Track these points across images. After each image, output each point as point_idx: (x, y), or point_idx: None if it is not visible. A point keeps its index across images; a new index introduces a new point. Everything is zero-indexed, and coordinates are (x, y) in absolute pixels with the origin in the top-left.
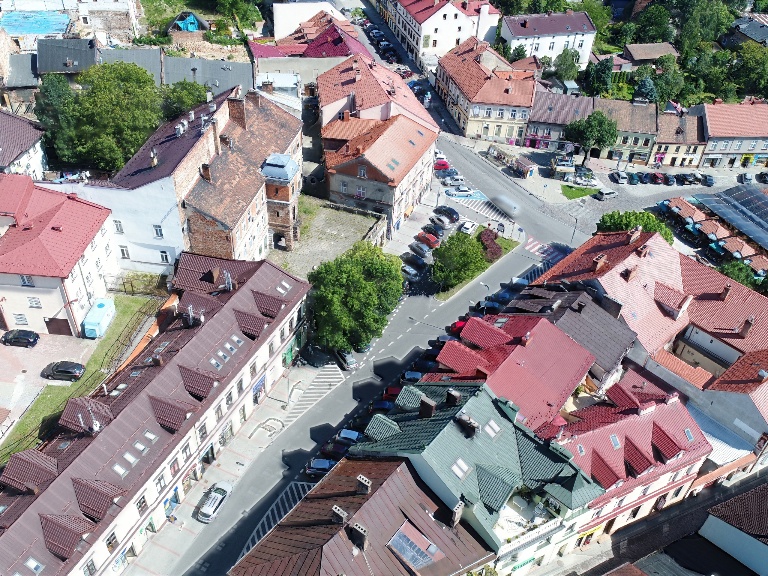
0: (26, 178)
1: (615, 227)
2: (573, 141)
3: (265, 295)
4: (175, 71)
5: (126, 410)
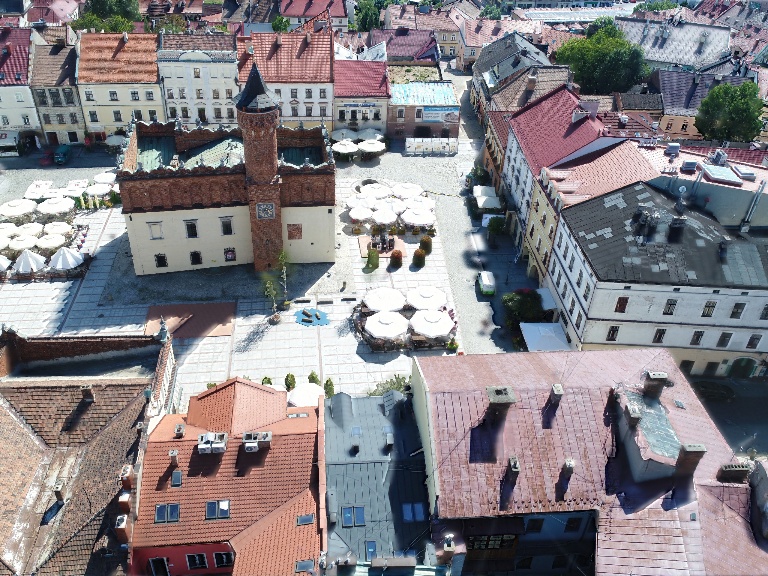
0: None
1: None
2: None
3: None
4: None
5: None
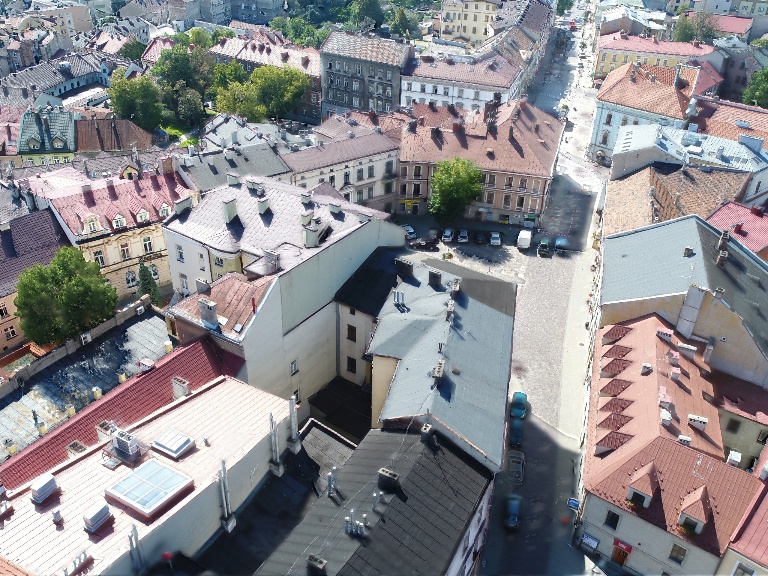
0: None
1: None
2: None
3: (6, 167)
4: None
5: (119, 156)
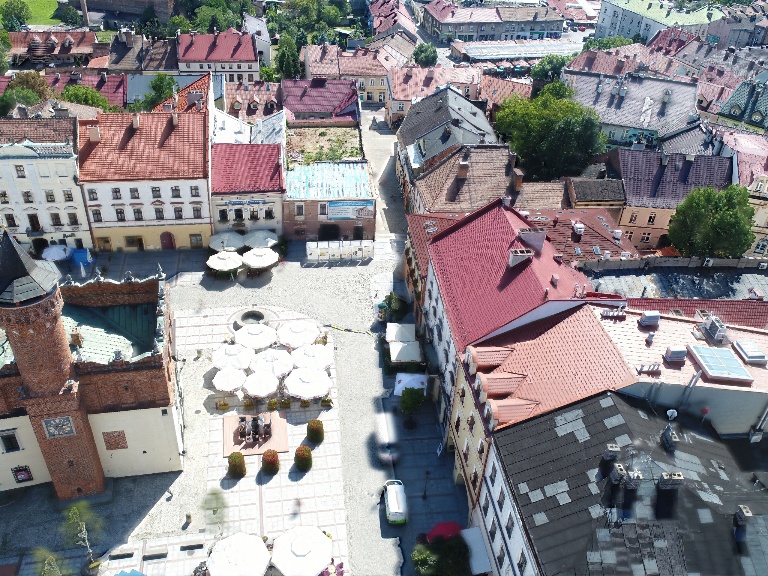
0: (711, 128)
1: (558, 66)
2: (428, 67)
3: None
4: (463, 116)
5: None
